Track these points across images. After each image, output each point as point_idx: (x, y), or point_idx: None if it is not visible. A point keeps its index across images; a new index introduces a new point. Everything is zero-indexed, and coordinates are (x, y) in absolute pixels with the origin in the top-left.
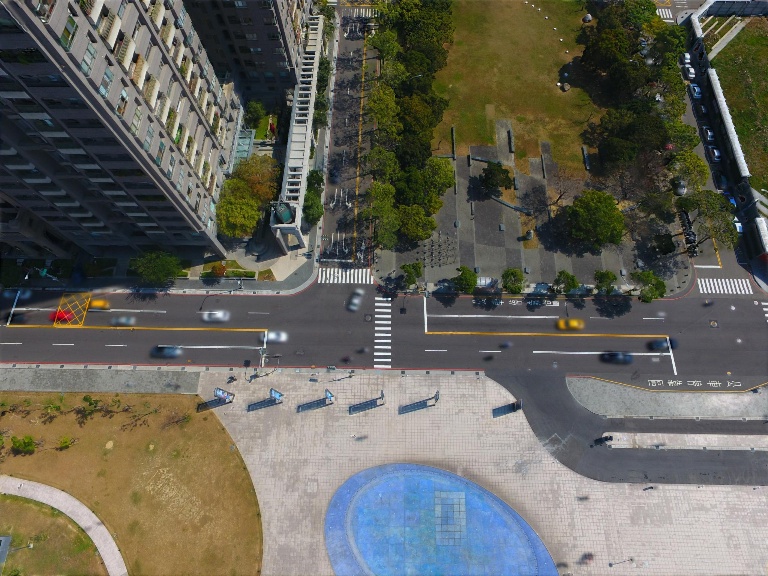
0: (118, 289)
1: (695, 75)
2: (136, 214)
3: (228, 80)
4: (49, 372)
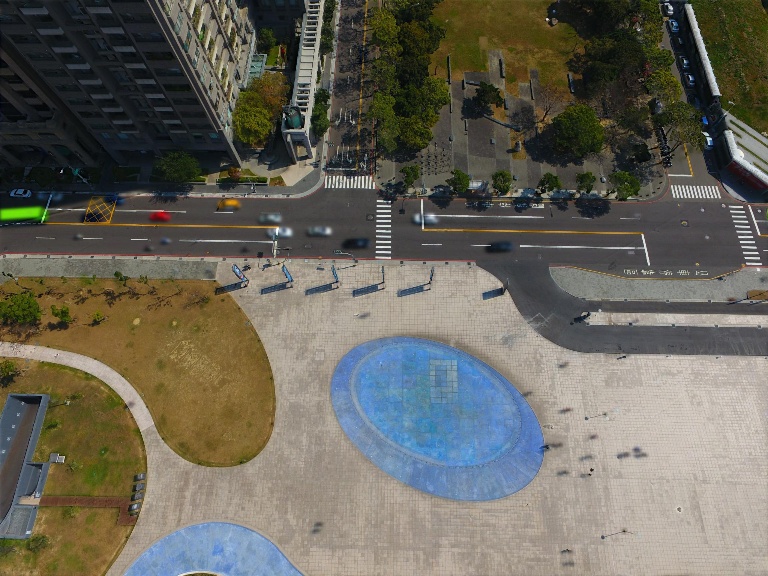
0: (142, 193)
1: (673, 12)
2: (163, 109)
3: (242, 5)
4: (80, 261)
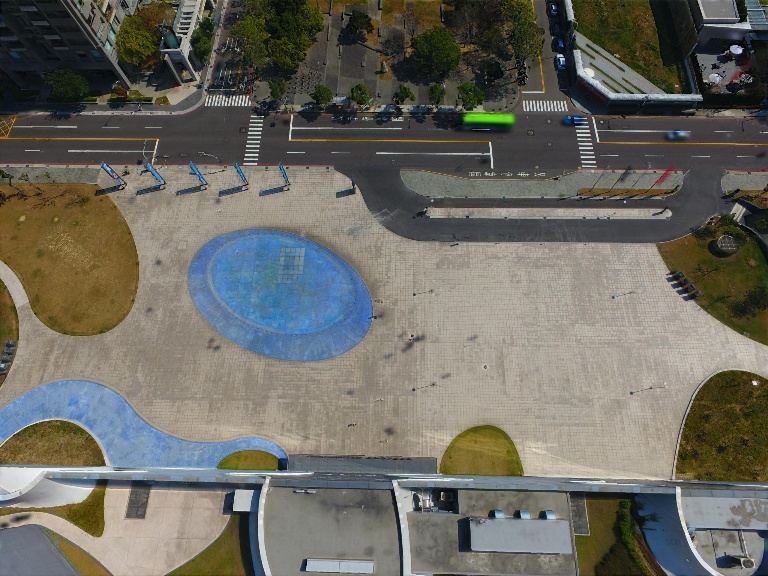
0: (39, 112)
1: None
2: (39, 23)
3: None
4: None
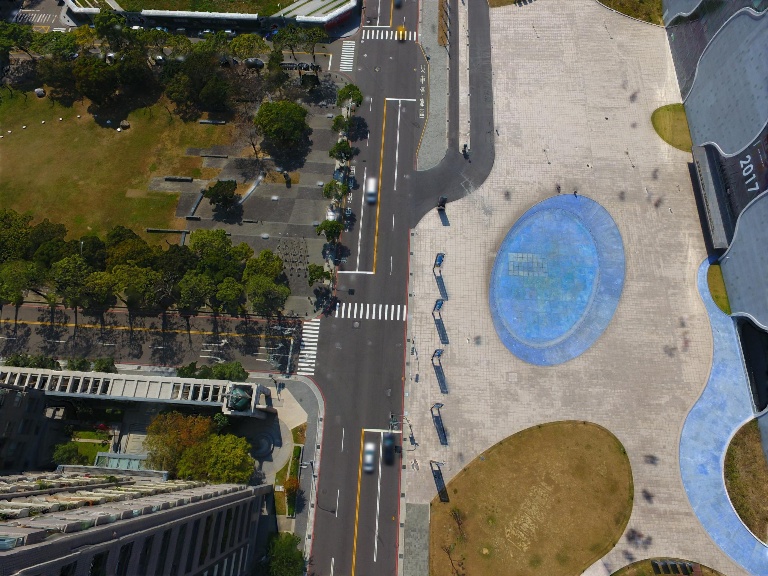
0: None
1: (141, 27)
2: (231, 569)
3: None
4: None
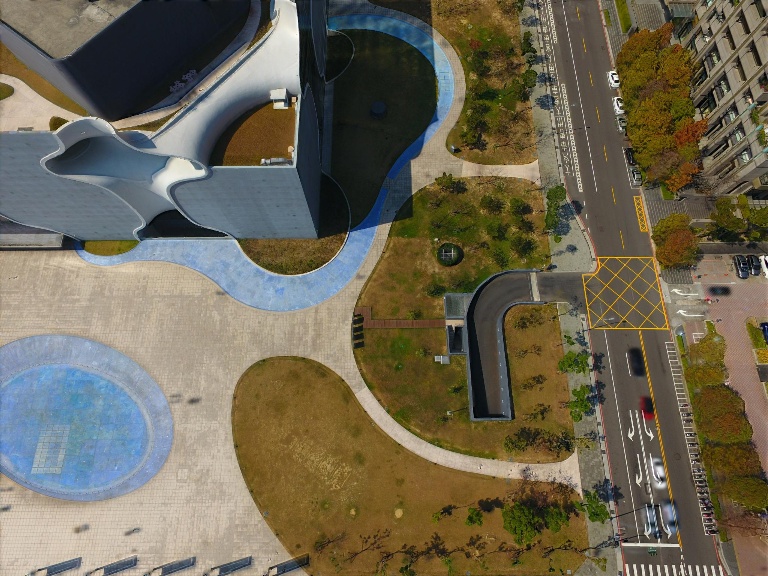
0: None
1: None
2: None
3: None
4: None
